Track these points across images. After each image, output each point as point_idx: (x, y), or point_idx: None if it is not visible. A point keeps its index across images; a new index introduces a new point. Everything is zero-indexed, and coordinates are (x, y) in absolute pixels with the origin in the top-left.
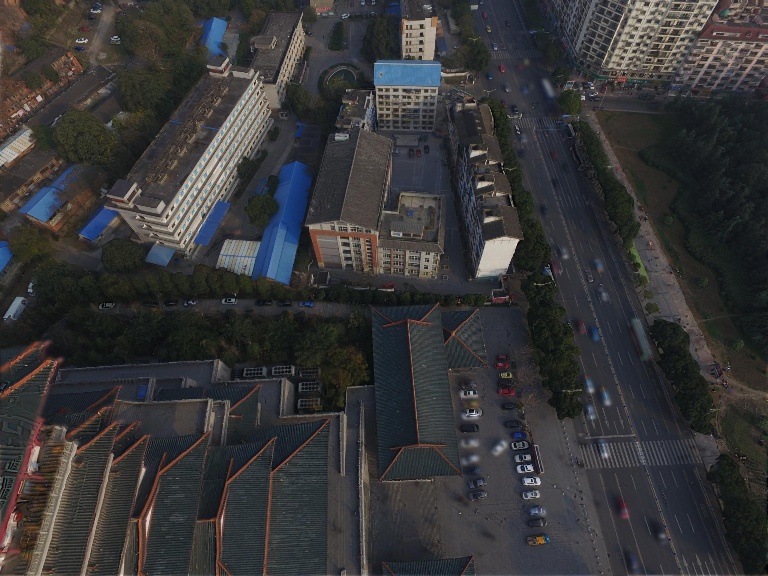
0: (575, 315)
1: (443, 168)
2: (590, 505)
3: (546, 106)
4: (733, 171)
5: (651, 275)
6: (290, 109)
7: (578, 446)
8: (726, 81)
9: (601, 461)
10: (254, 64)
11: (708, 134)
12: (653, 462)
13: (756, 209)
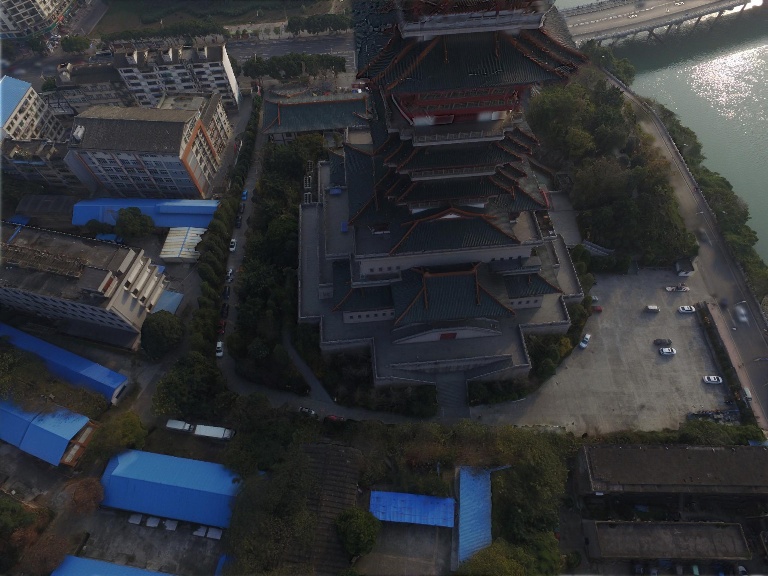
0: None
1: None
2: None
3: None
4: None
5: None
6: None
7: None
8: None
9: None
10: None
11: None
12: None
13: None
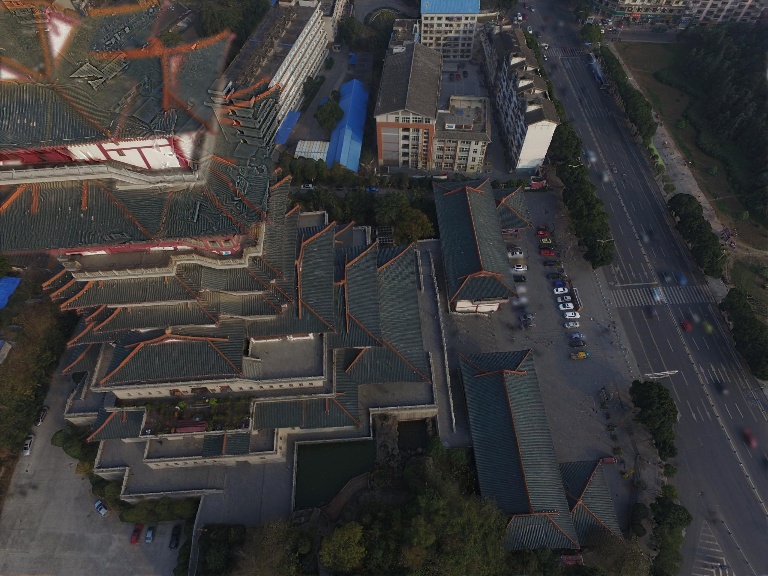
0: (603, 197)
1: (481, 89)
2: (622, 332)
3: (569, 39)
4: (738, 81)
5: (668, 166)
6: (343, 42)
7: (610, 291)
8: (731, 13)
9: (629, 301)
10: None
11: (715, 52)
12: (673, 301)
13: (758, 108)
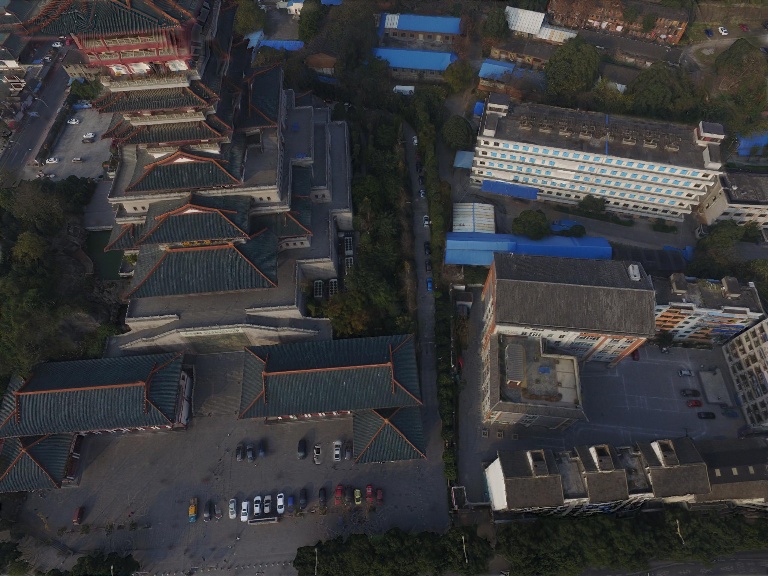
0: None
1: None
2: None
3: None
4: None
5: None
6: None
7: None
8: None
9: None
10: (760, 177)
11: None
12: None
13: None
